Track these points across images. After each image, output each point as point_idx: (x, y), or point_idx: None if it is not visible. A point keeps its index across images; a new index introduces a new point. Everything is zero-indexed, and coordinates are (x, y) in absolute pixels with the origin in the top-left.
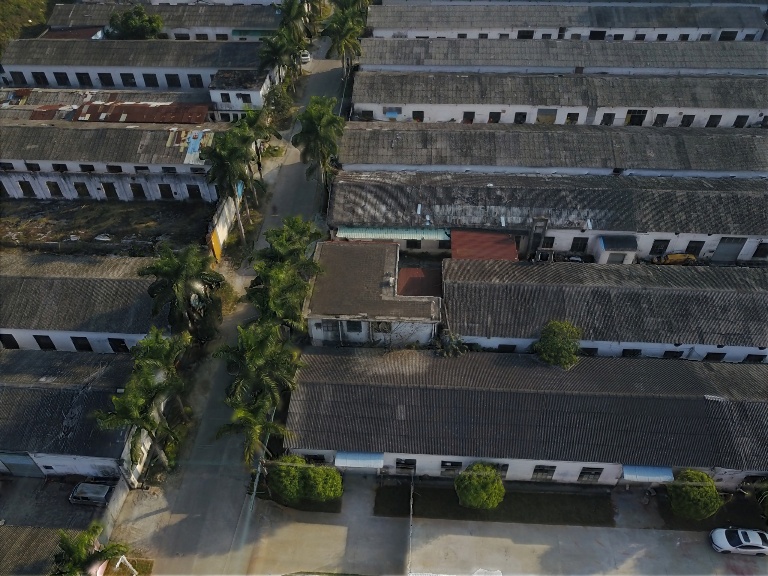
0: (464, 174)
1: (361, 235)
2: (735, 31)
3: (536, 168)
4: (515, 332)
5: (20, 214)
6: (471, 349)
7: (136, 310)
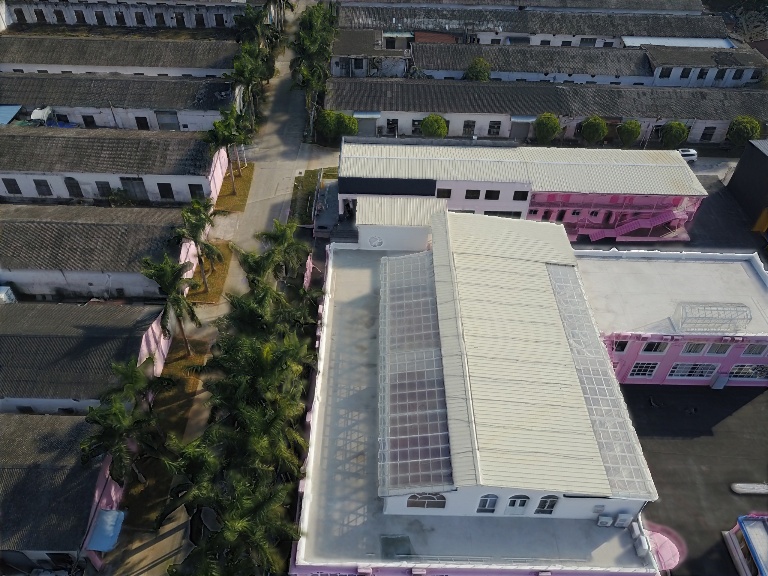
0: (422, 7)
1: None
2: None
3: (469, 6)
4: (453, 67)
5: (117, 34)
6: (428, 78)
7: (224, 57)
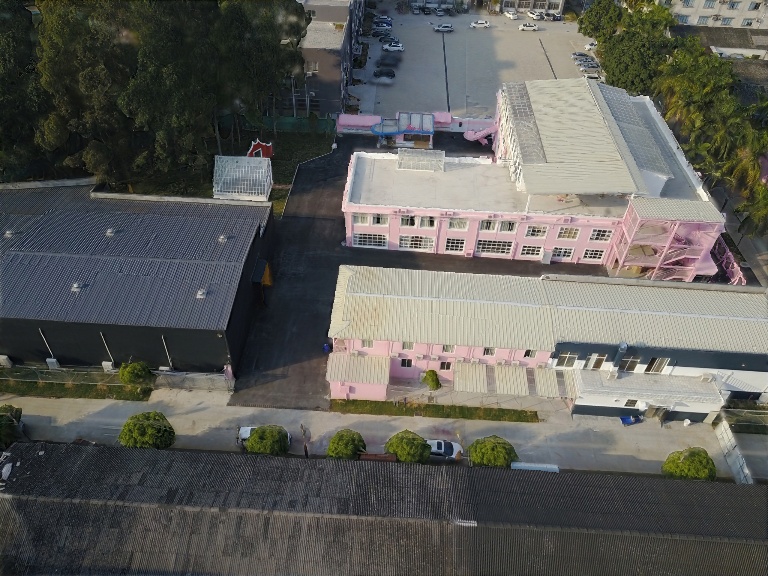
0: None
1: None
2: None
3: None
4: None
5: None
6: None
7: None
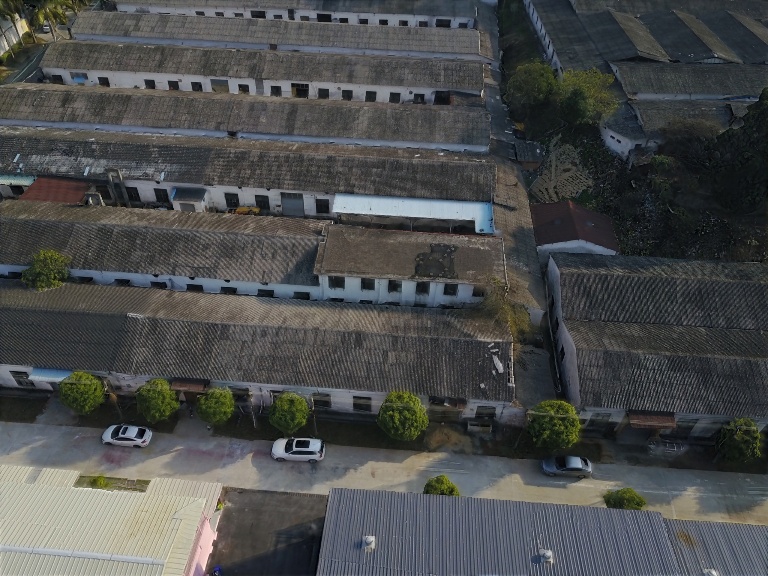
0: (87, 131)
1: None
2: (449, 19)
3: (158, 128)
4: (15, 260)
5: None
6: None
7: None
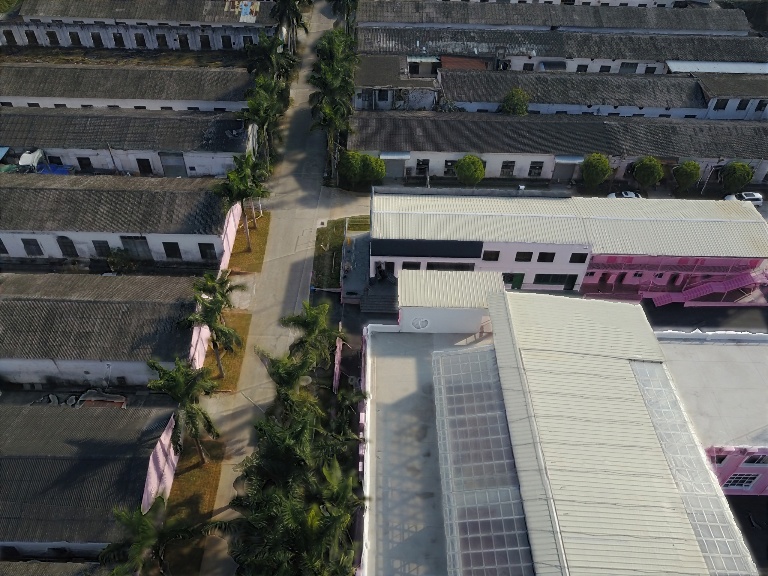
0: (447, 28)
1: None
2: None
3: (497, 26)
4: (488, 99)
5: (115, 57)
6: (459, 110)
7: (234, 88)
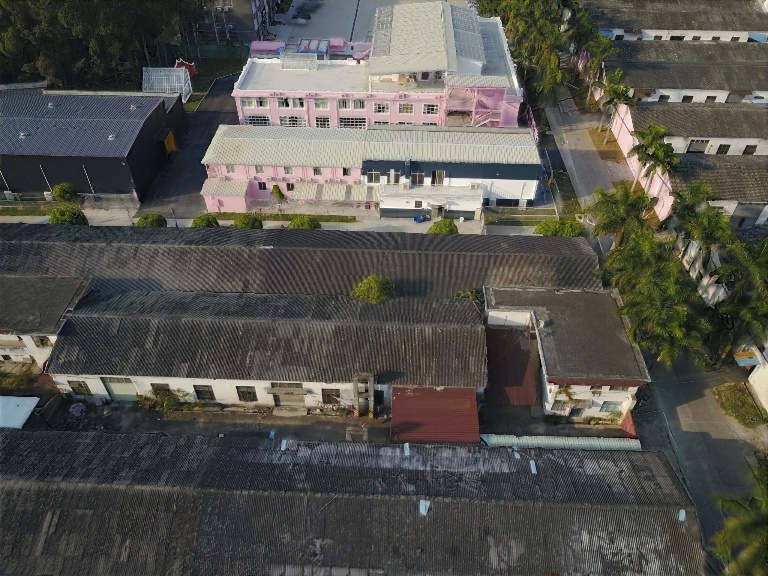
0: None
1: (605, 441)
2: None
3: None
4: (411, 299)
5: None
6: None
7: None
